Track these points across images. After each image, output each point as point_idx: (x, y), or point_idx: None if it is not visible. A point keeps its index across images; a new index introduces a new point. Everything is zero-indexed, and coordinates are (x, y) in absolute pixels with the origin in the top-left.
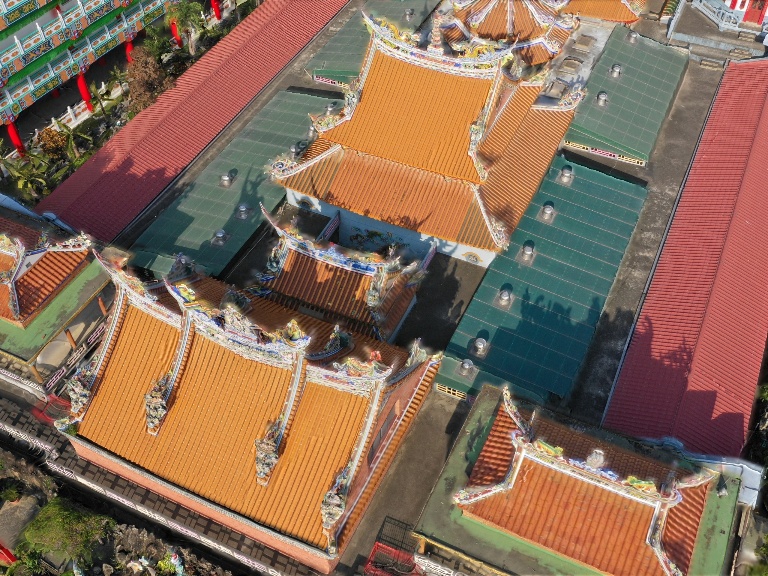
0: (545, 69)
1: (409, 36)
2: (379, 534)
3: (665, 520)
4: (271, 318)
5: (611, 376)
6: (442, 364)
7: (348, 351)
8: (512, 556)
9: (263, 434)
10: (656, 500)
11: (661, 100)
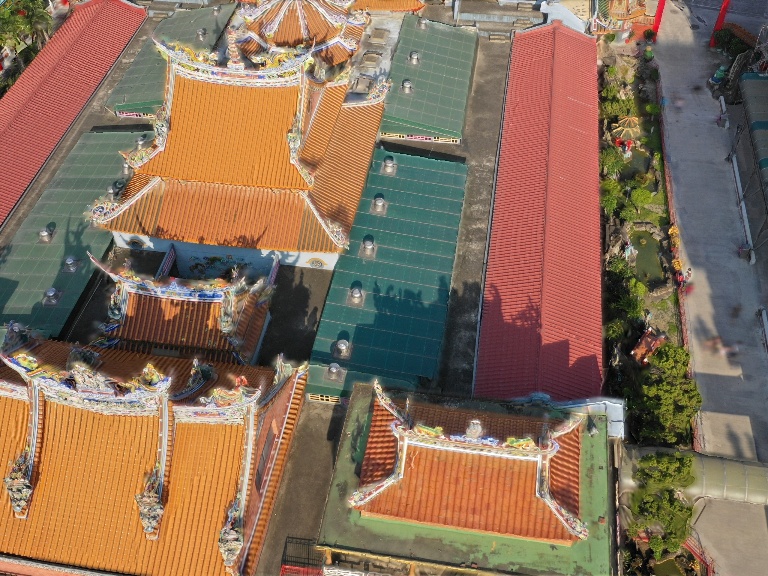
0: None
1: (206, 56)
2: (283, 557)
3: (549, 471)
4: (125, 367)
5: (472, 348)
6: (309, 374)
7: (212, 383)
8: (417, 543)
9: (142, 488)
10: (537, 454)
11: (461, 79)
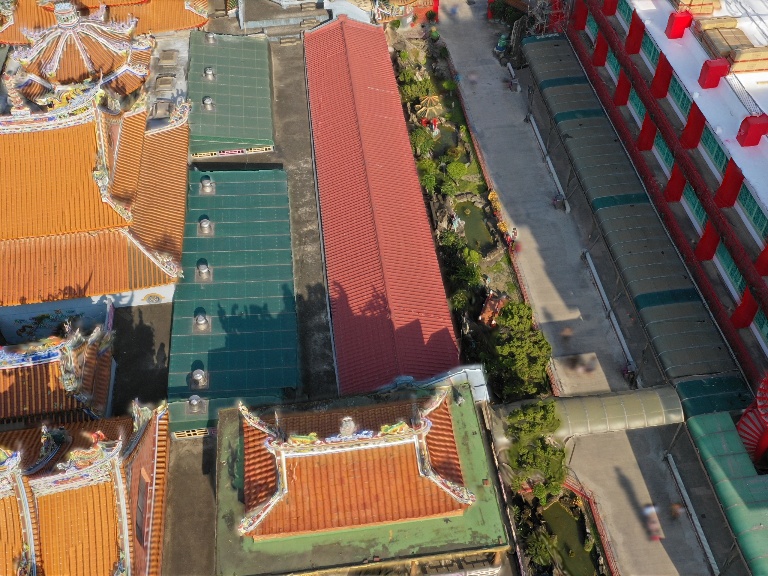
0: (142, 94)
1: None
2: None
3: (427, 448)
4: None
5: (328, 348)
6: (170, 412)
7: (68, 446)
8: (316, 553)
9: (13, 575)
10: (412, 435)
11: (261, 87)
